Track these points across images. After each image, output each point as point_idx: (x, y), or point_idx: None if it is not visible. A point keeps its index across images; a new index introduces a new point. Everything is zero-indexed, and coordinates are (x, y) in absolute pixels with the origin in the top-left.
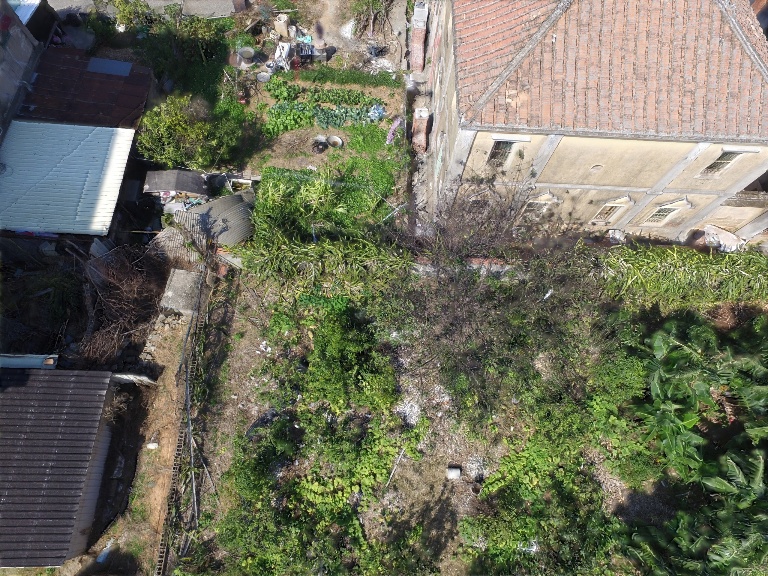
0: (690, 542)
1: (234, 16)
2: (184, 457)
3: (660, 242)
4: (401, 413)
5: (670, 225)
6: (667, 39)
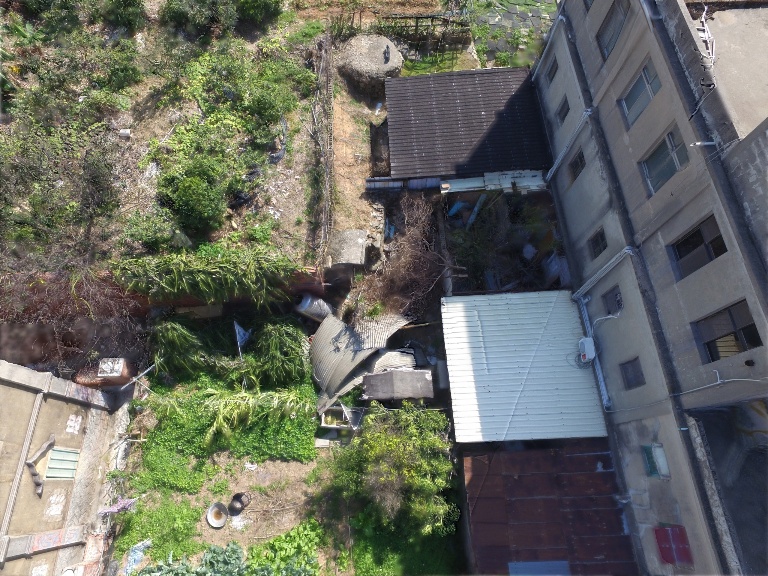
0: None
1: None
2: None
3: None
4: None
5: None
6: None
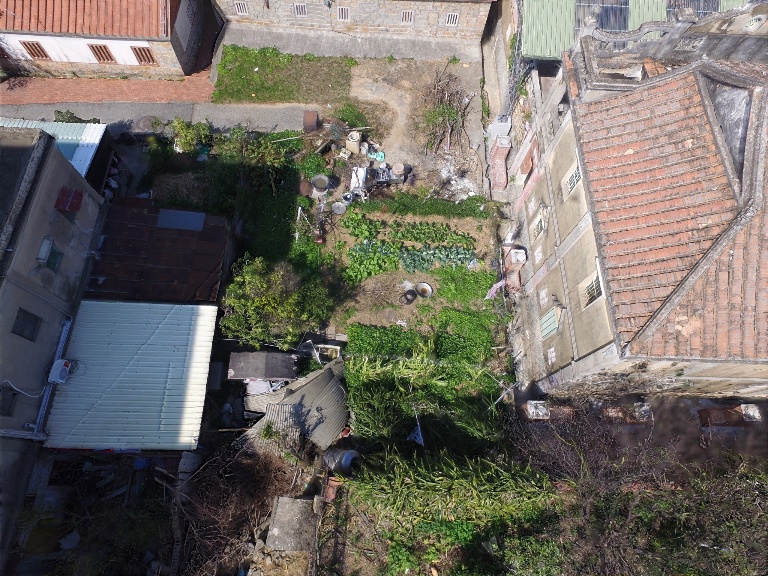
0: None
1: (304, 138)
2: None
3: None
4: None
5: None
6: None
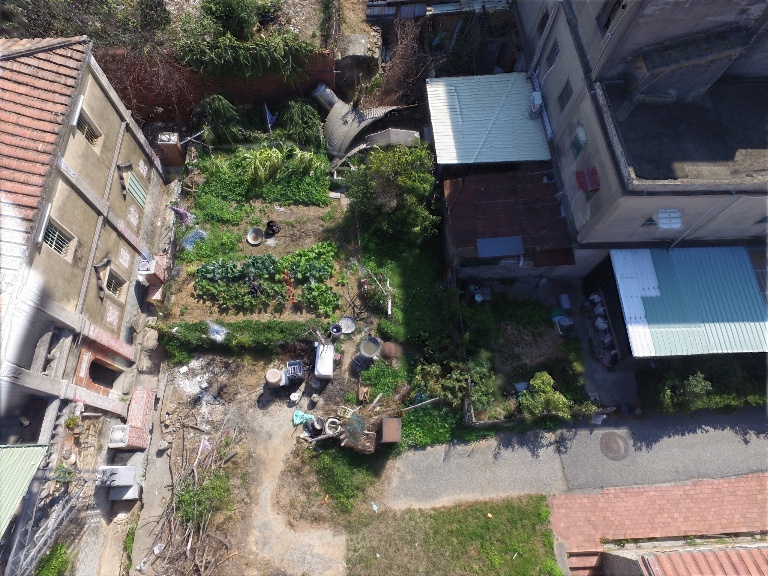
0: None
1: (398, 408)
2: None
3: None
4: None
5: None
6: None
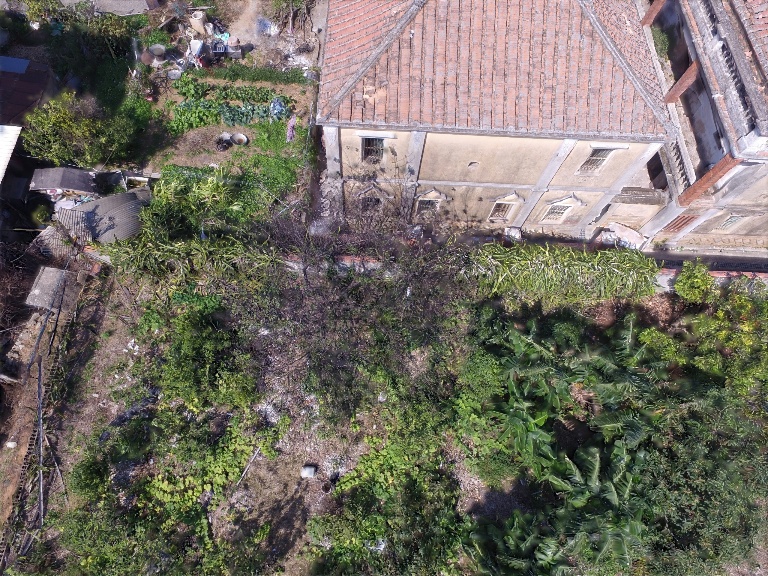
0: (521, 541)
1: (147, 13)
2: (35, 456)
3: (564, 240)
4: (262, 411)
5: (569, 223)
6: (527, 35)
